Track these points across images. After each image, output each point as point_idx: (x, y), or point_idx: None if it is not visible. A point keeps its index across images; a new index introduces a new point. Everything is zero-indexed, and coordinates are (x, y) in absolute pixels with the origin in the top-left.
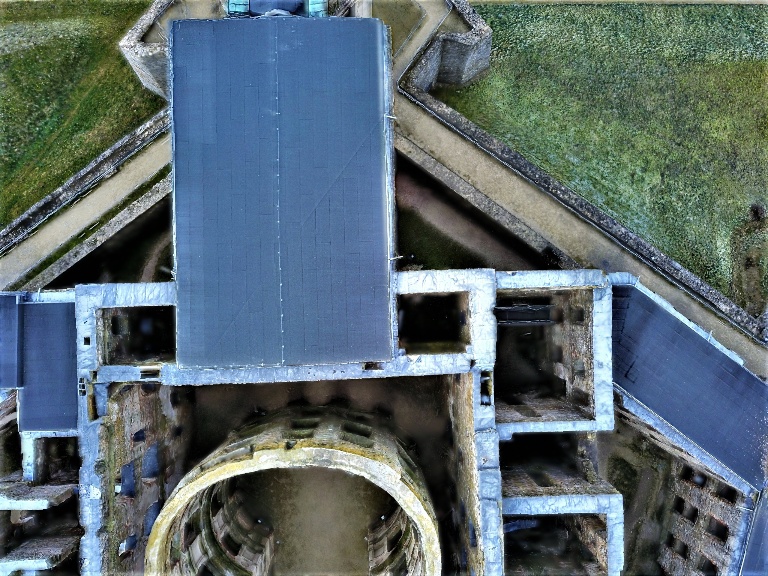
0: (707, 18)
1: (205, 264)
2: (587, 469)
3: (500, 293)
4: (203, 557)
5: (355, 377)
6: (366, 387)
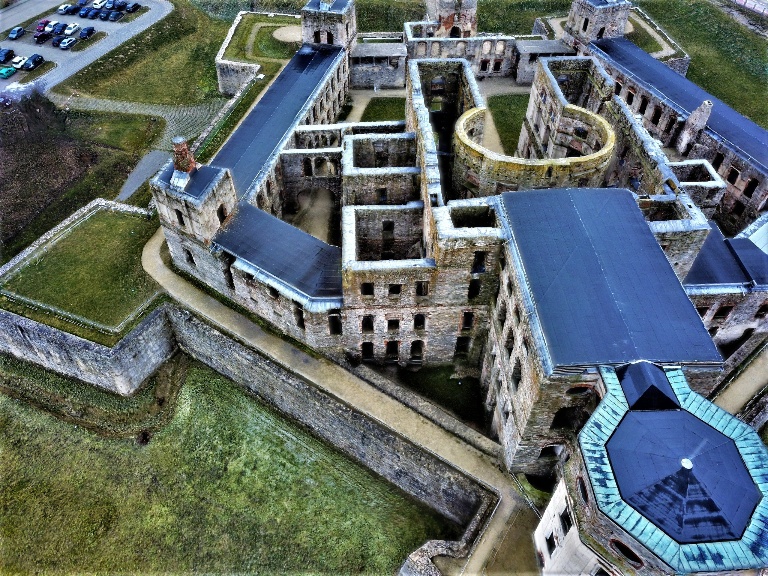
0: None
1: (633, 230)
2: None
3: None
4: None
5: None
6: None
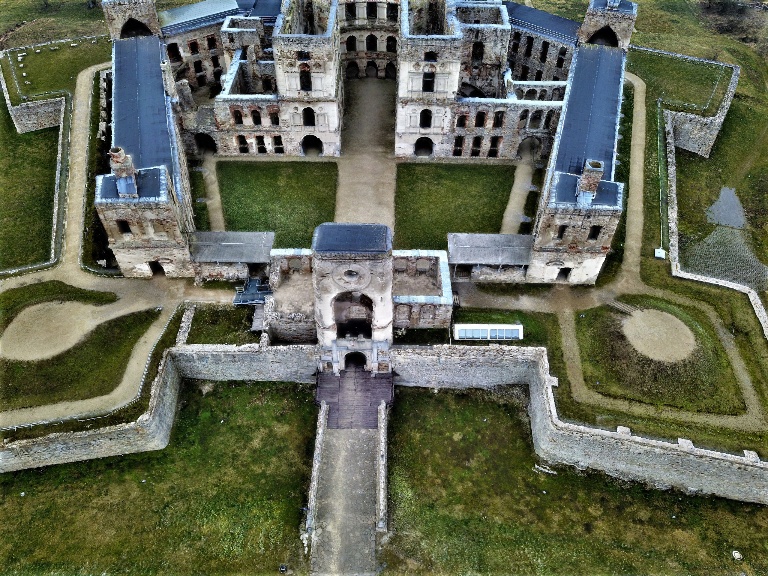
0: None
1: None
2: None
3: None
4: None
5: None
6: None
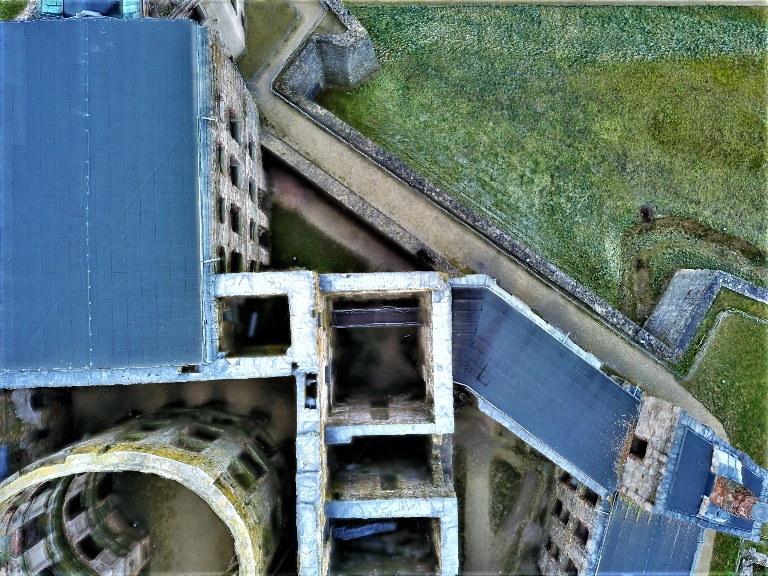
0: (604, 19)
1: (14, 267)
2: (435, 472)
3: (355, 295)
4: (46, 562)
5: (170, 380)
6: (243, 390)
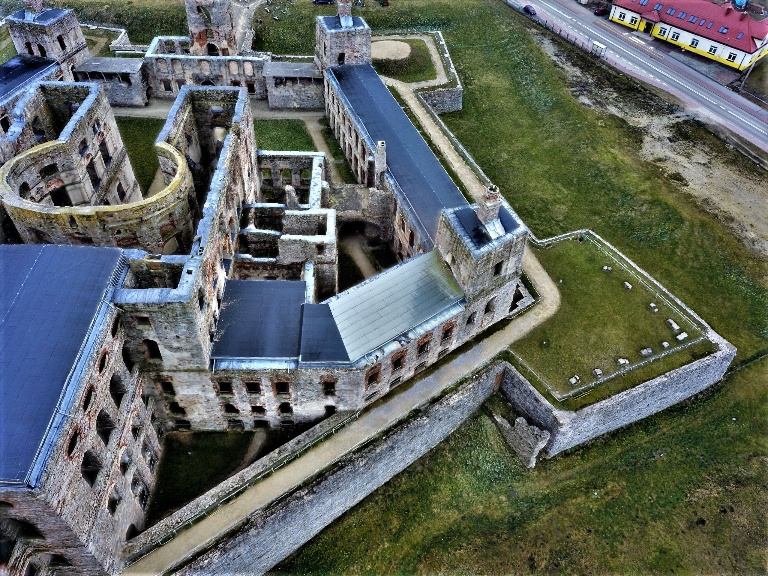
0: None
1: (77, 301)
2: None
3: None
4: None
5: None
6: None
